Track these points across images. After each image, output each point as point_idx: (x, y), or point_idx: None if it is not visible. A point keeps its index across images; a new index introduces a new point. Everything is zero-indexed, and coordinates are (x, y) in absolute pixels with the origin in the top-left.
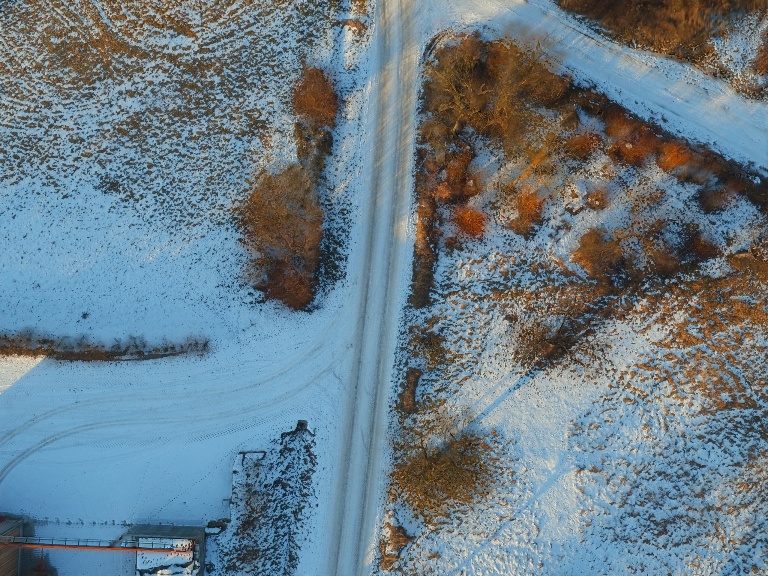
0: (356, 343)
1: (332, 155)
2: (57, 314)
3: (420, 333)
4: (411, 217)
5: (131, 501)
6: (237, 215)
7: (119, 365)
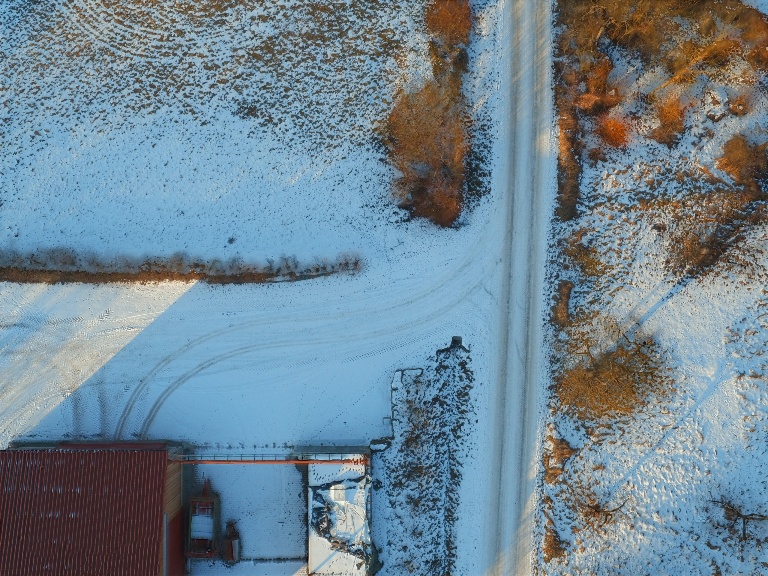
0: (505, 258)
1: (469, 72)
2: (203, 240)
3: (569, 245)
4: (553, 130)
5: (291, 423)
6: (377, 135)
7: (271, 287)
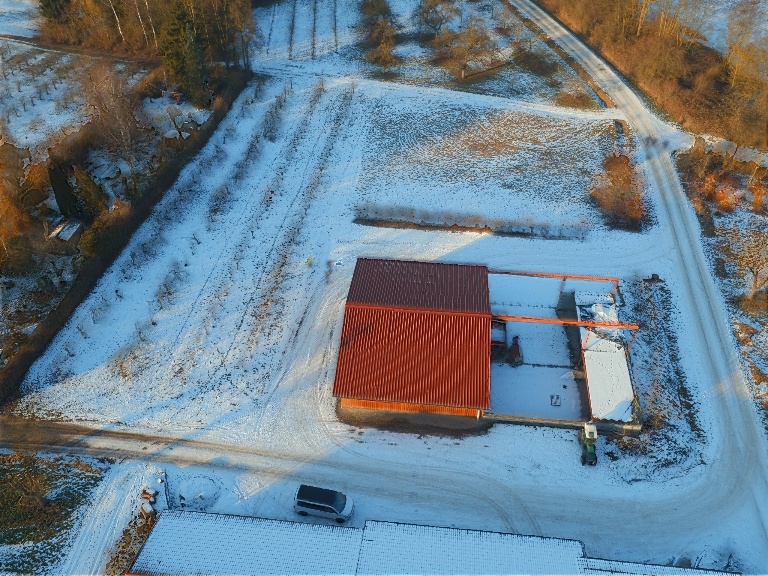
0: (676, 248)
1: (632, 184)
2: None
3: (715, 247)
4: (689, 205)
5: (552, 297)
6: (584, 200)
7: (532, 241)
